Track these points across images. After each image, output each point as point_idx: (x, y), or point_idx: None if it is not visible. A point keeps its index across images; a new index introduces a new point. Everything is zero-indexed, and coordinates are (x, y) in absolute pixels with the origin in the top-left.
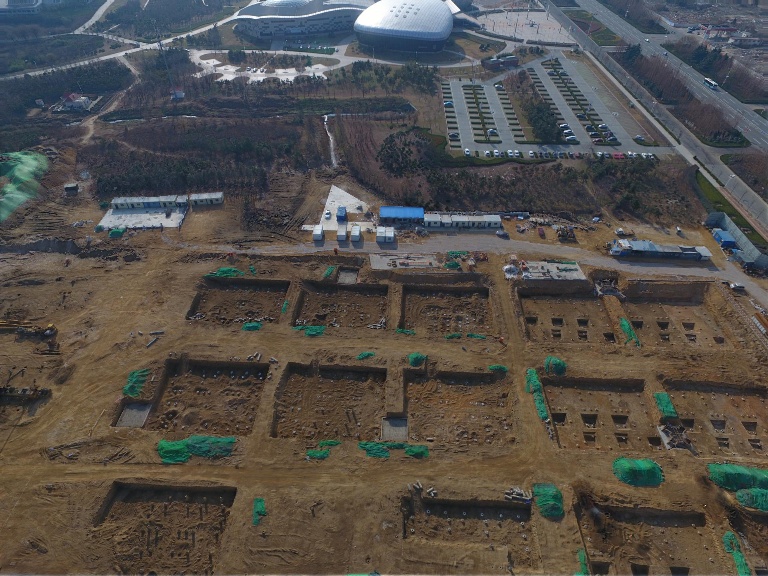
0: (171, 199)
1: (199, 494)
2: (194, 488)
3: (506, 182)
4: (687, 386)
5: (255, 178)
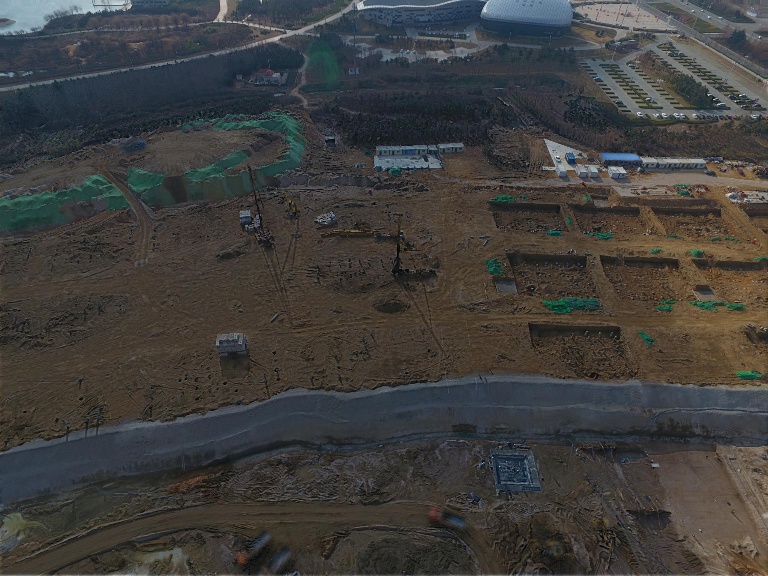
0: (424, 147)
1: (591, 332)
2: (588, 328)
3: (692, 135)
4: None
5: (477, 133)
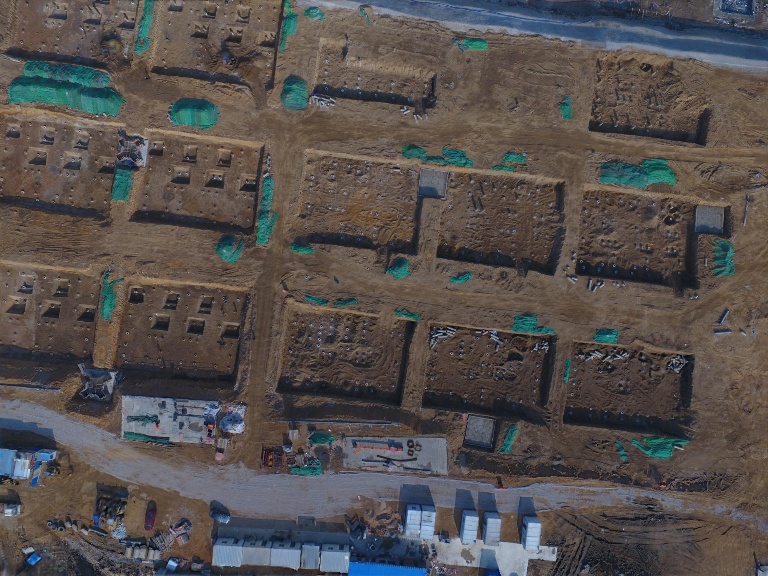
0: None
1: None
2: None
3: None
4: (80, 213)
5: None
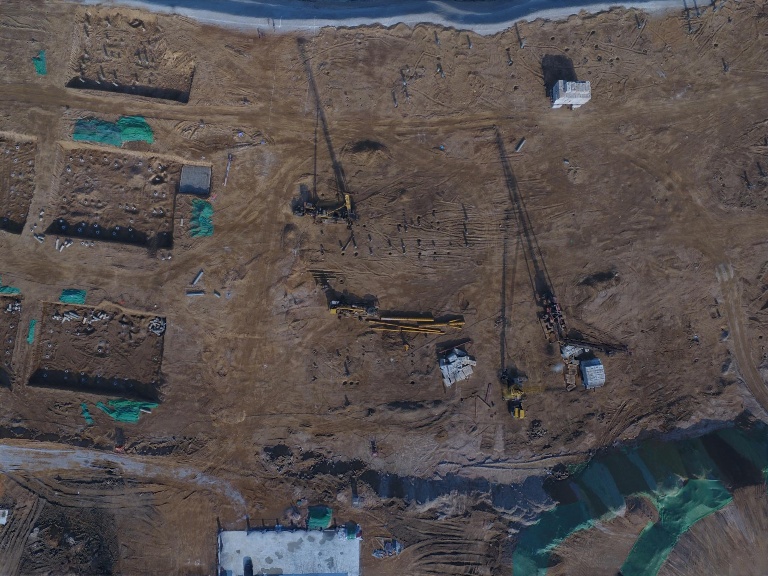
0: None
1: (108, 90)
2: None
3: None
4: None
5: None
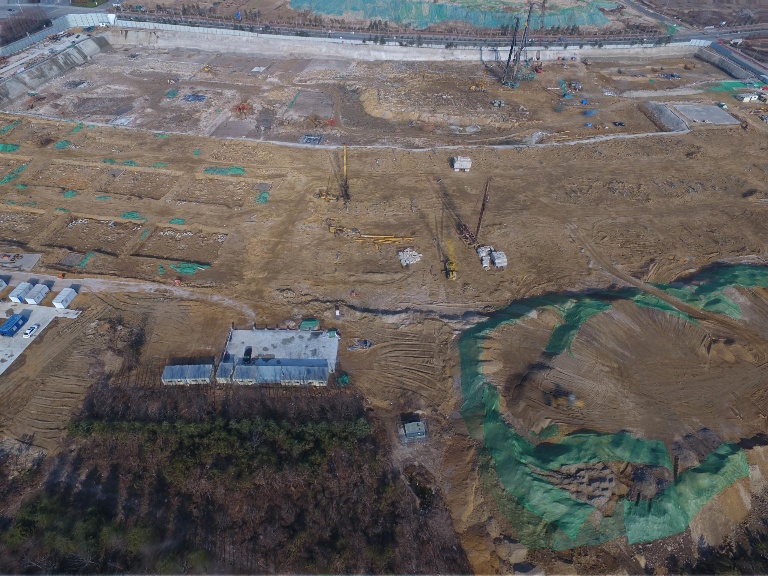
0: (241, 368)
1: None
2: None
3: None
4: None
5: None
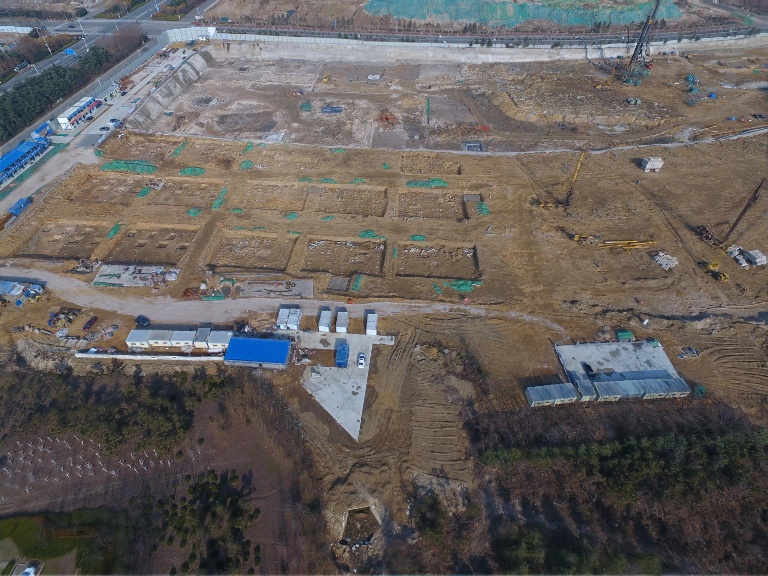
0: (601, 385)
1: None
2: None
3: None
4: None
5: None
